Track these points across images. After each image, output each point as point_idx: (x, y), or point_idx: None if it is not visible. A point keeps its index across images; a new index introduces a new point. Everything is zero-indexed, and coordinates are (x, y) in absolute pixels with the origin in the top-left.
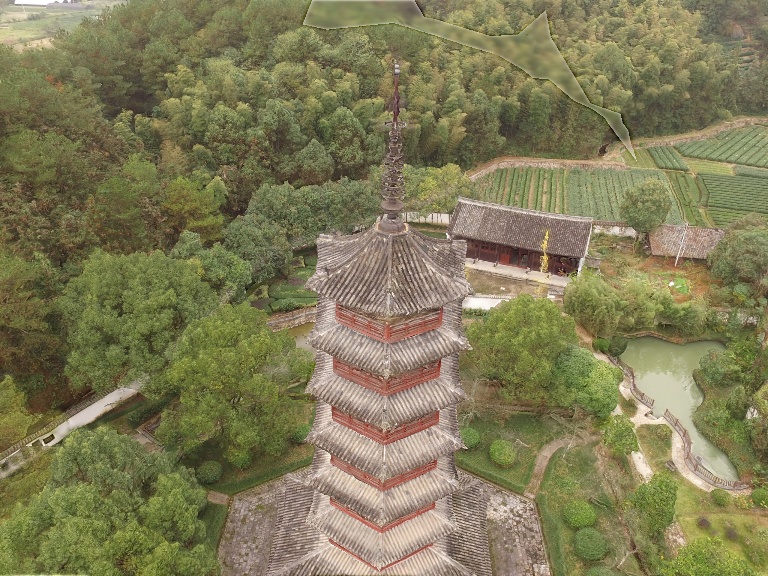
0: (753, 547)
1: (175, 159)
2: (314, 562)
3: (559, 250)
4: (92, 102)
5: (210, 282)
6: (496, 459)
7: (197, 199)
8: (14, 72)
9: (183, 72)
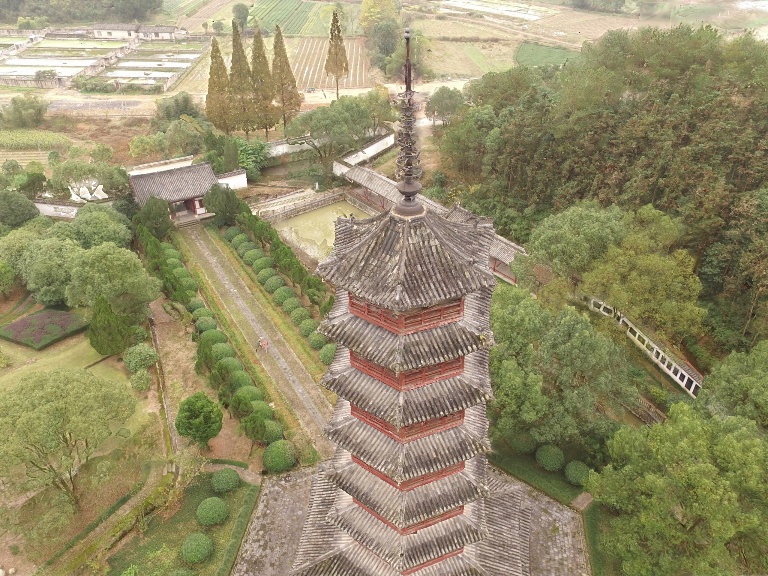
0: None
1: None
2: None
3: None
4: None
5: None
6: None
7: None
8: None
9: None
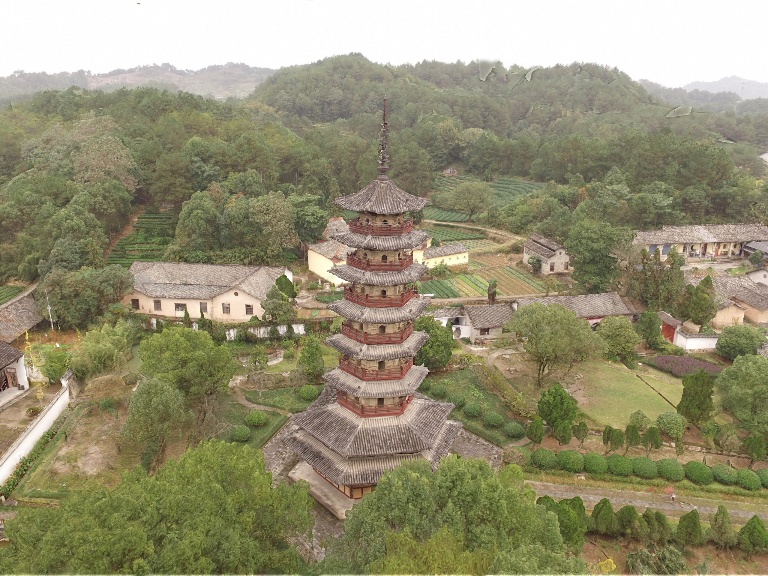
0: (320, 352)
1: None
2: (414, 426)
3: (2, 362)
4: None
5: None
6: (265, 420)
7: None
8: None
9: None
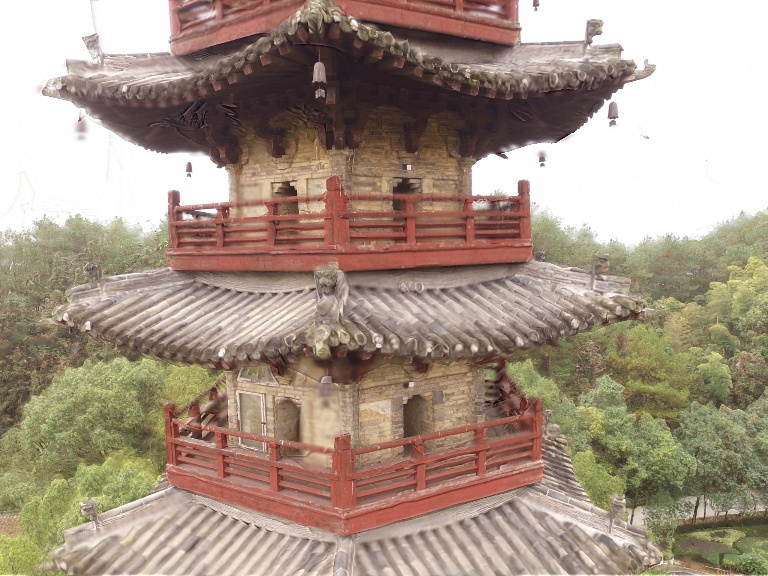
0: None
1: (676, 332)
2: None
3: None
4: (634, 288)
5: (605, 449)
6: None
7: (653, 355)
8: (537, 221)
9: (752, 264)
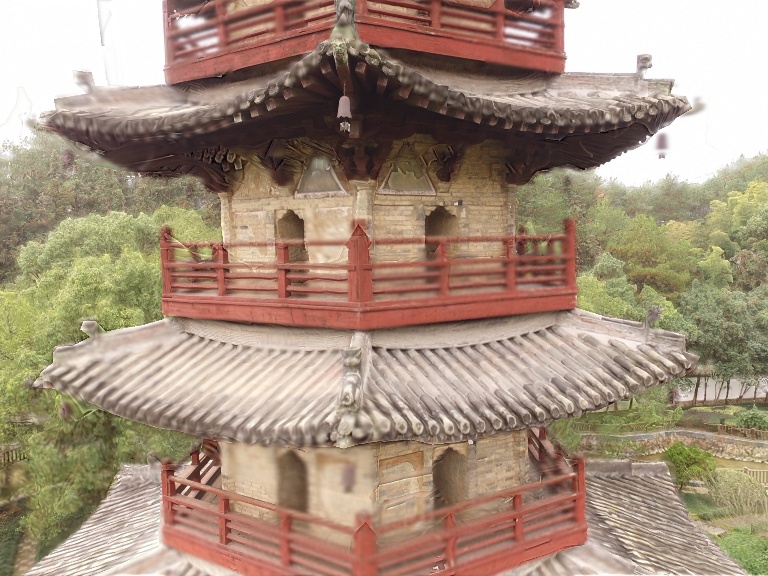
0: None
1: (677, 239)
2: None
3: None
4: None
5: None
6: None
7: (654, 240)
8: None
9: (752, 188)
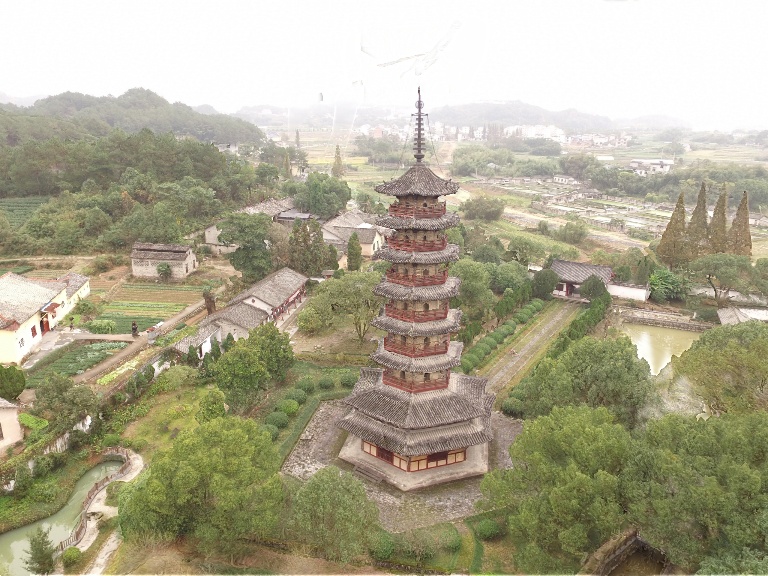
0: (160, 425)
1: None
2: None
3: None
4: None
5: None
6: None
7: None
8: None
9: None
